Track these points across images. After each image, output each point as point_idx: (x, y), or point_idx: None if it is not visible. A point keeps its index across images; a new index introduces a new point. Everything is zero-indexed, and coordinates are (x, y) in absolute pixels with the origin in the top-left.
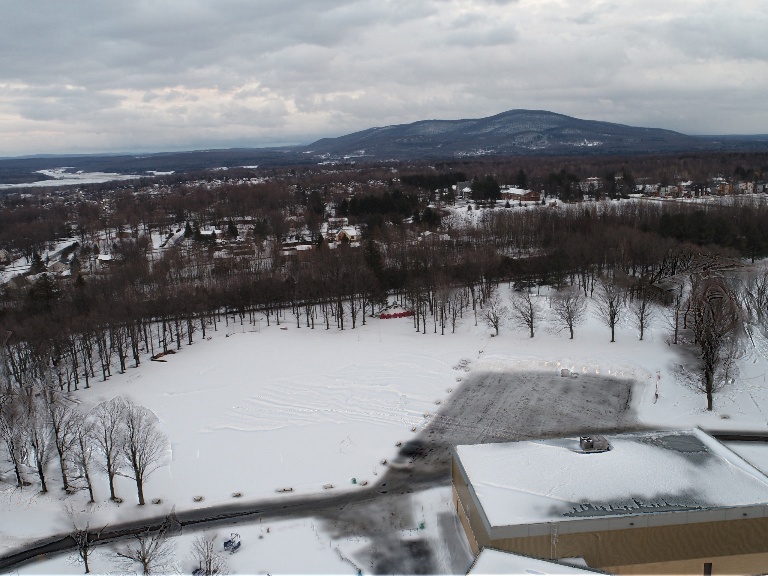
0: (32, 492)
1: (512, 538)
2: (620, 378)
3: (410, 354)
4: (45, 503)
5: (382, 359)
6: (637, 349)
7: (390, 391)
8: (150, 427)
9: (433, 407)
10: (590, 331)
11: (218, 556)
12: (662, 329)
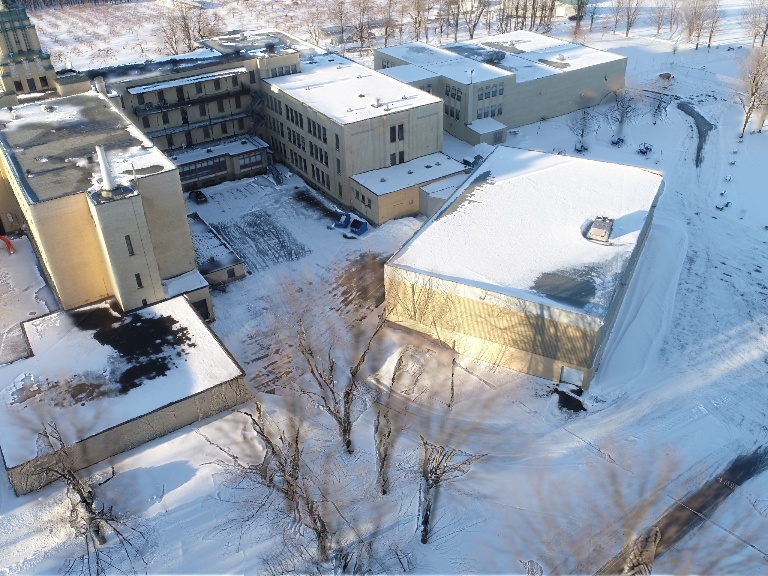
0: None
1: None
2: None
3: None
4: None
5: None
6: None
7: None
8: (766, 77)
9: None
10: None
11: (593, 116)
12: None
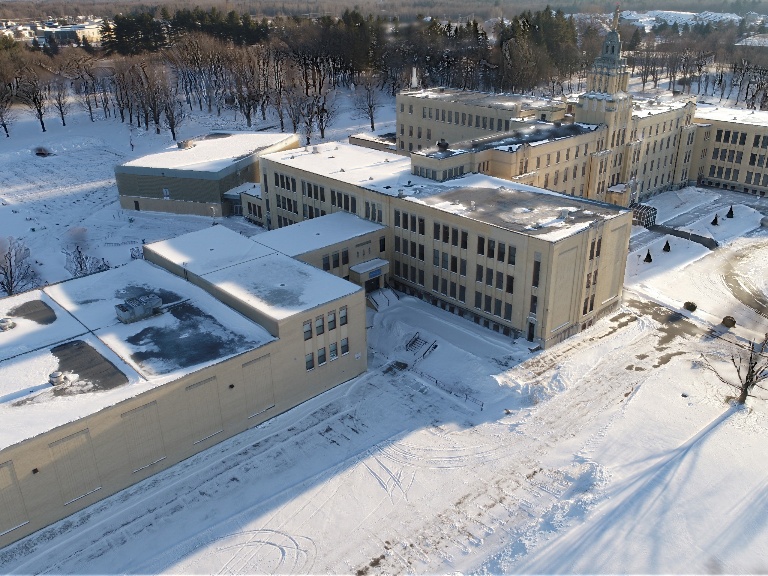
0: None
1: (225, 177)
2: (86, 147)
3: None
4: None
5: None
6: (71, 131)
7: None
8: None
9: None
10: (26, 125)
11: None
12: (81, 112)
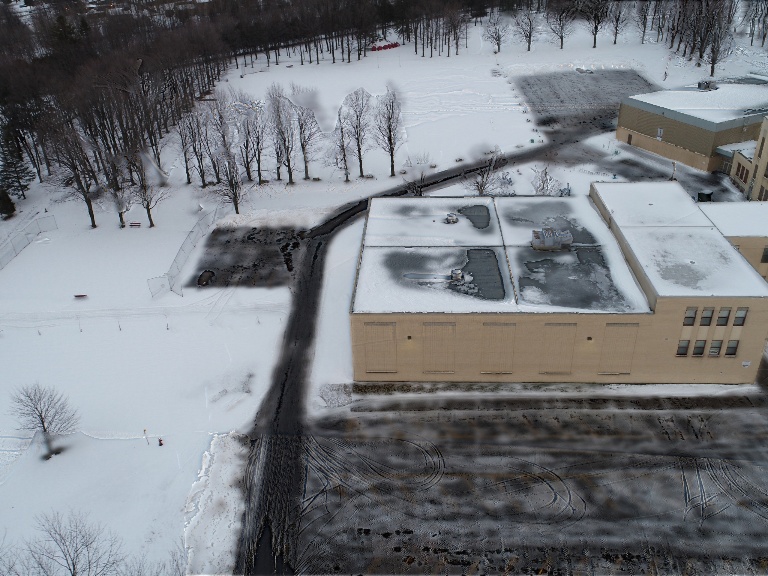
0: (280, 185)
1: (725, 130)
2: (623, 70)
3: (451, 69)
4: (304, 189)
5: (429, 75)
6: (618, 50)
7: (472, 93)
8: (399, 109)
9: (518, 99)
10: (579, 40)
11: None
12: (635, 32)
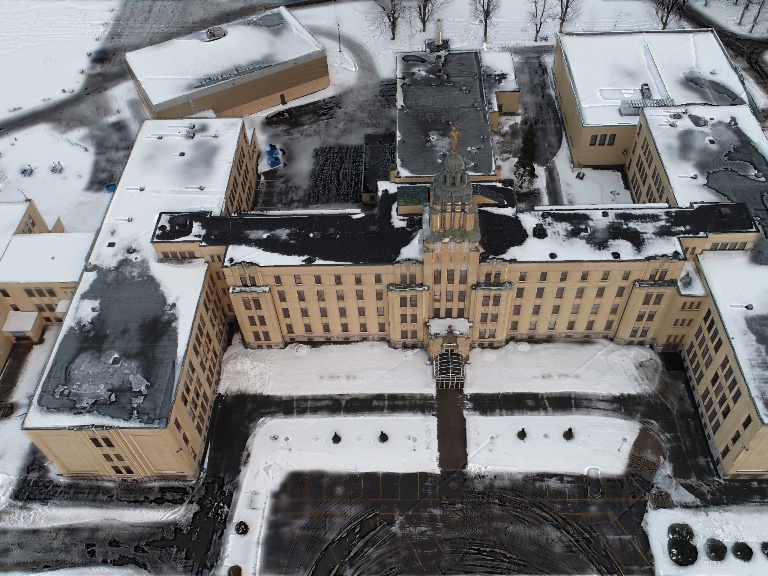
0: None
1: (167, 108)
2: None
3: None
4: None
5: None
6: None
7: (69, 6)
8: None
9: (108, 15)
10: None
11: None
12: None
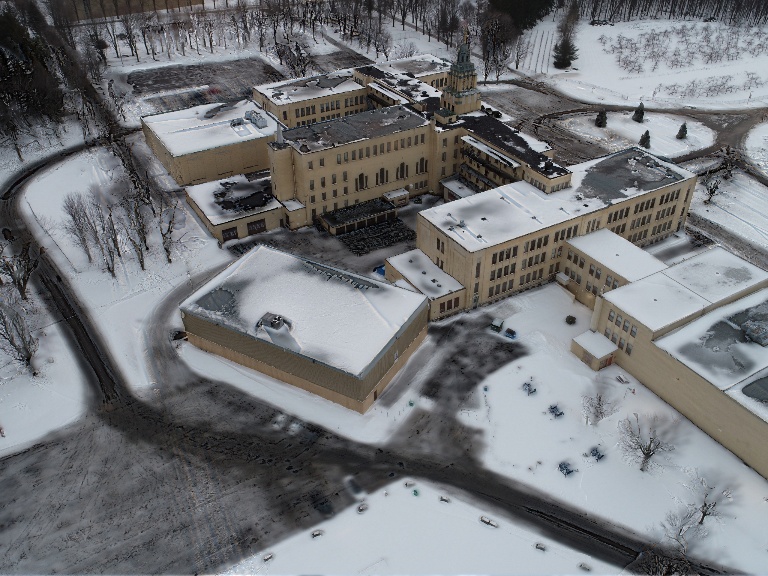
0: None
1: None
2: None
3: None
4: None
5: None
6: None
7: None
8: None
9: None
10: None
11: None
12: None
